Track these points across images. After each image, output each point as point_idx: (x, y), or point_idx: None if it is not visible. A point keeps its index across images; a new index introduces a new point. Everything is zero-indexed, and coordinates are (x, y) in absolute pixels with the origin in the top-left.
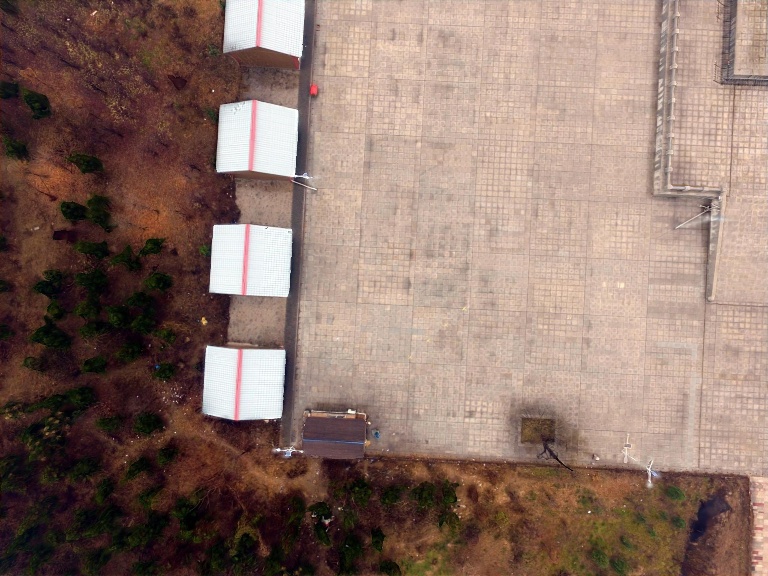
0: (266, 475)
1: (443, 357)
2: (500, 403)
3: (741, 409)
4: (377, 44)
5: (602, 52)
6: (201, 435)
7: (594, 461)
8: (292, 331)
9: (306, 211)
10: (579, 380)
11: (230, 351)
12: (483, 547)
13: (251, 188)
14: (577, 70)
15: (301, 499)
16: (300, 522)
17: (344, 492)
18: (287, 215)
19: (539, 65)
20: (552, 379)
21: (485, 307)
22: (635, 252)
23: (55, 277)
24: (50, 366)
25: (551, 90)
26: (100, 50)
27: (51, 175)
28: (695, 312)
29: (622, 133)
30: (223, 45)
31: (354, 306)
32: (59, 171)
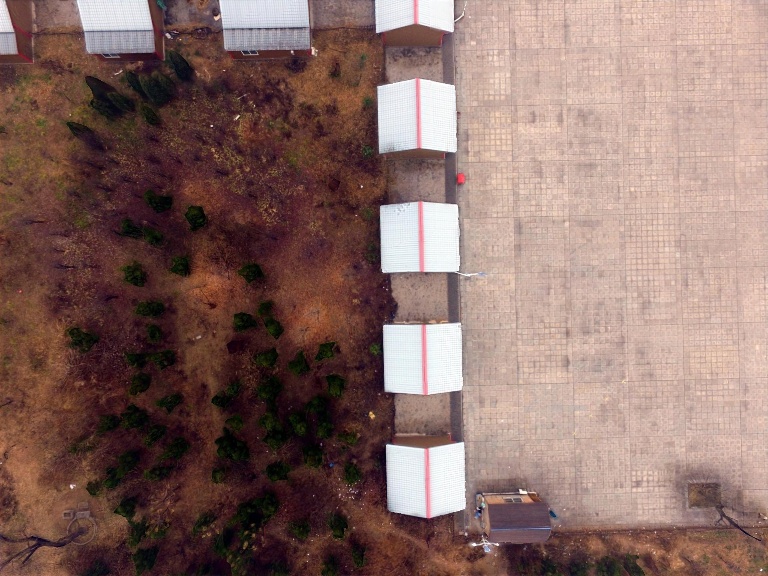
0: (446, 562)
1: (606, 430)
2: (665, 471)
3: None
4: (518, 127)
5: (739, 120)
6: (379, 528)
7: (760, 520)
8: (457, 417)
9: (461, 298)
10: (740, 442)
11: (415, 450)
12: None
13: (406, 280)
14: (716, 139)
15: None
16: None
17: None
18: (443, 304)
19: (679, 137)
20: (714, 443)
21: (643, 378)
22: None
23: (235, 391)
24: (227, 474)
25: (692, 161)
26: (246, 154)
27: (208, 283)
28: None
29: (764, 198)
30: (378, 146)
31: (516, 388)
32: (216, 279)
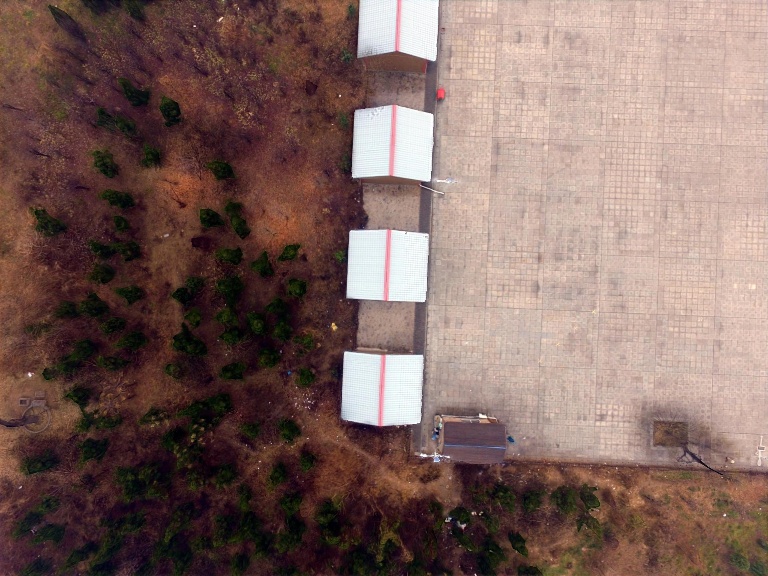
0: (399, 480)
1: (573, 361)
2: (631, 406)
3: None
4: (503, 47)
5: (731, 52)
6: (333, 441)
7: (727, 464)
8: (421, 336)
9: (433, 215)
10: (711, 383)
11: (372, 357)
12: (617, 551)
13: (378, 193)
14: (705, 70)
15: (440, 504)
16: (434, 527)
17: (488, 497)
18: (415, 219)
19: (667, 66)
20: (683, 382)
21: (615, 310)
22: (766, 253)
23: (196, 284)
24: (184, 373)
25: (679, 91)
26: (227, 56)
27: (180, 182)
28: None
29: (752, 133)
30: (357, 50)
31: (483, 310)
32: (188, 178)
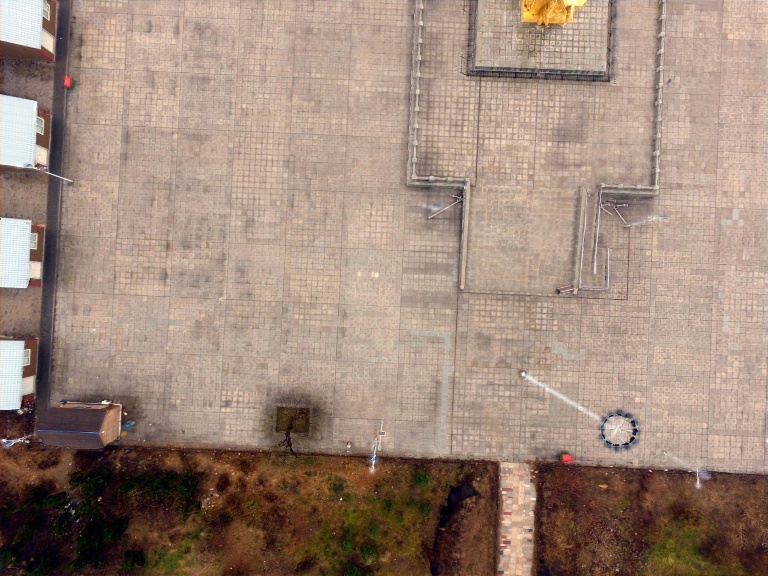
0: (18, 467)
1: (200, 347)
2: (256, 392)
3: (493, 396)
4: (133, 36)
5: (356, 44)
6: None
7: (348, 449)
8: (48, 323)
9: (63, 203)
10: (334, 369)
11: None
12: (236, 535)
13: (6, 180)
14: (332, 62)
15: (42, 490)
16: (52, 513)
17: (77, 482)
18: (42, 207)
19: (294, 57)
20: (308, 368)
21: (241, 297)
22: (389, 242)
23: None
24: None
25: (306, 82)
26: None
27: None
28: (448, 301)
29: (376, 124)
30: None
31: (111, 297)
32: None
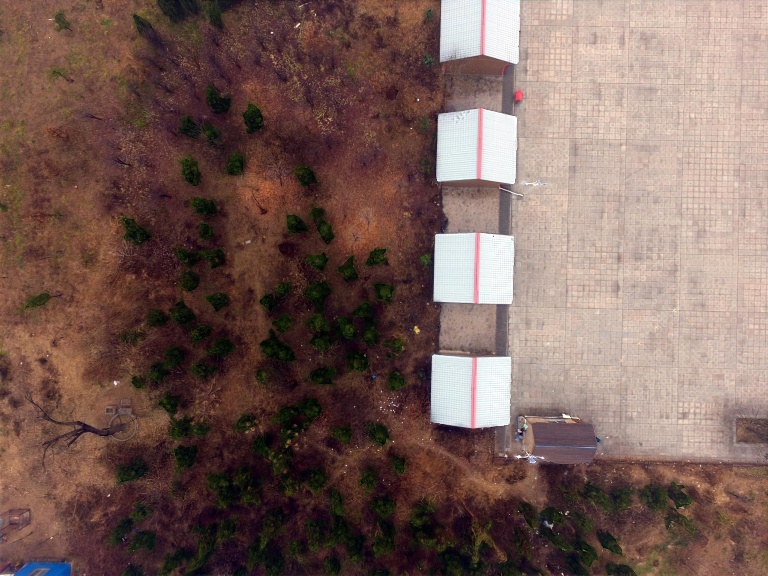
0: (485, 482)
1: (654, 359)
2: (713, 404)
3: None
4: (579, 48)
5: None
6: (419, 443)
7: None
8: (503, 337)
9: (512, 217)
10: None
11: (462, 359)
12: (703, 548)
13: (458, 196)
14: None
15: (530, 505)
16: (520, 527)
17: (580, 497)
18: (494, 222)
19: (743, 65)
20: (765, 378)
21: (695, 308)
22: None
23: (285, 290)
24: (270, 379)
25: (755, 89)
26: (305, 62)
27: (261, 188)
28: None
29: None
30: (440, 54)
31: (563, 311)
32: (268, 184)
